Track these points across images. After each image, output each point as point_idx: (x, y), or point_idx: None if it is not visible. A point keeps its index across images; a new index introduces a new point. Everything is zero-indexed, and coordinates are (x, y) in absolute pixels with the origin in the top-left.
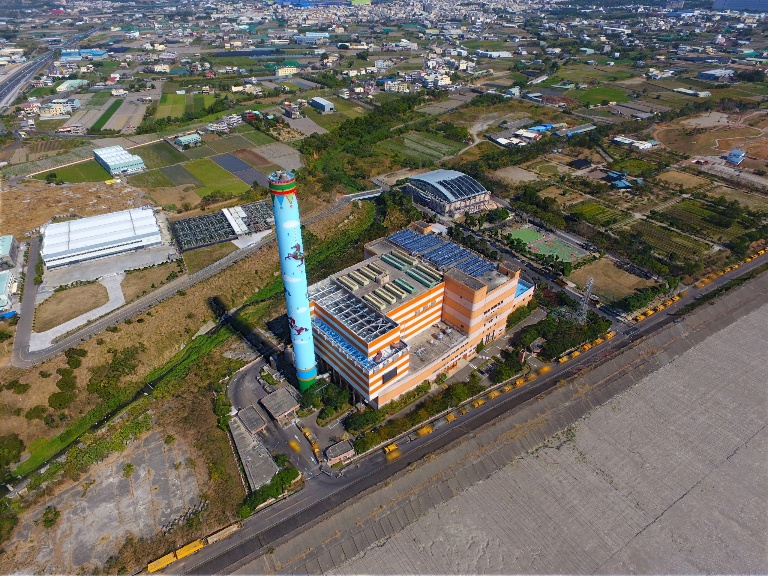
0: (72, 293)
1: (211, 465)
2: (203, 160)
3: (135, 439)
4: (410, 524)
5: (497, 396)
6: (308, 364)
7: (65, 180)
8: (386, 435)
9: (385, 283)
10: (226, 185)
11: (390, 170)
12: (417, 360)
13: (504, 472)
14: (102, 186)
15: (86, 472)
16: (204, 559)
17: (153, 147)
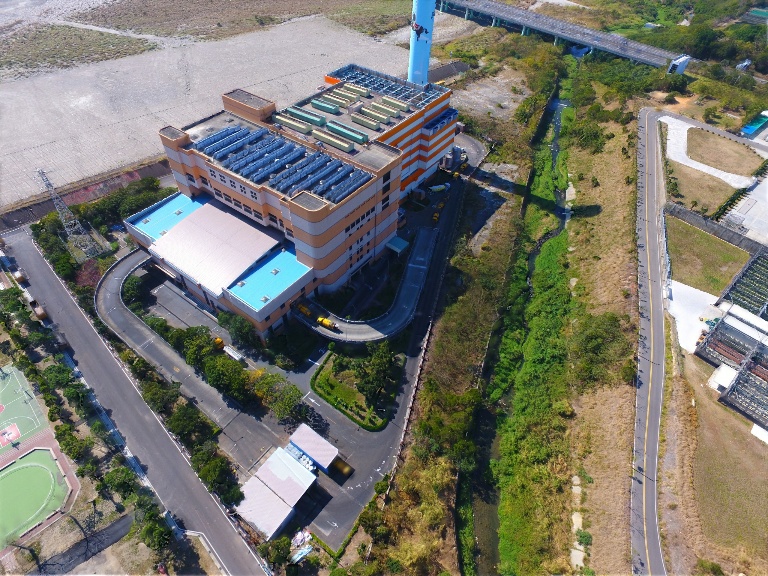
0: (747, 161)
1: None
2: None
3: None
4: None
5: None
6: None
7: None
8: None
9: None
10: None
11: None
12: None
13: None
14: None
15: None
16: None
17: None
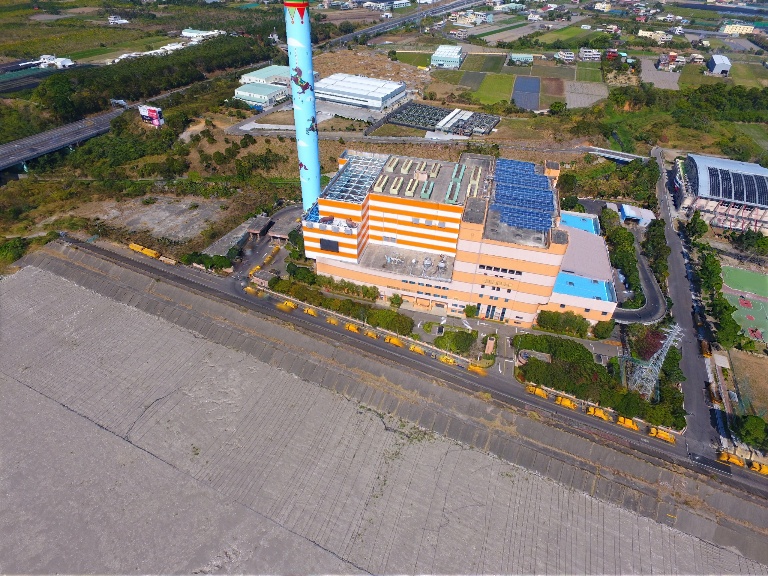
0: None
1: (210, 228)
2: (509, 76)
3: (216, 197)
4: (223, 345)
5: (417, 352)
6: (308, 207)
7: (401, 60)
8: (295, 292)
9: (419, 181)
10: (492, 96)
11: (698, 149)
12: (380, 263)
13: (320, 391)
14: (412, 69)
15: (184, 196)
16: (149, 263)
17: (490, 57)
